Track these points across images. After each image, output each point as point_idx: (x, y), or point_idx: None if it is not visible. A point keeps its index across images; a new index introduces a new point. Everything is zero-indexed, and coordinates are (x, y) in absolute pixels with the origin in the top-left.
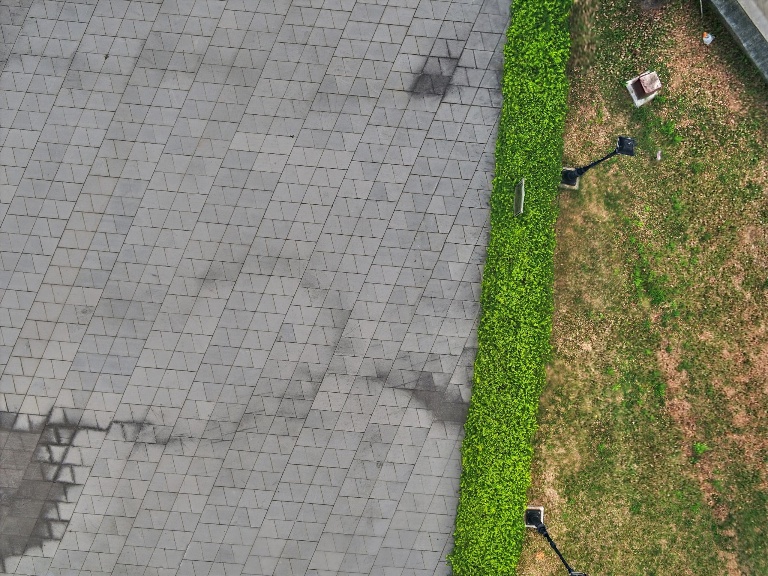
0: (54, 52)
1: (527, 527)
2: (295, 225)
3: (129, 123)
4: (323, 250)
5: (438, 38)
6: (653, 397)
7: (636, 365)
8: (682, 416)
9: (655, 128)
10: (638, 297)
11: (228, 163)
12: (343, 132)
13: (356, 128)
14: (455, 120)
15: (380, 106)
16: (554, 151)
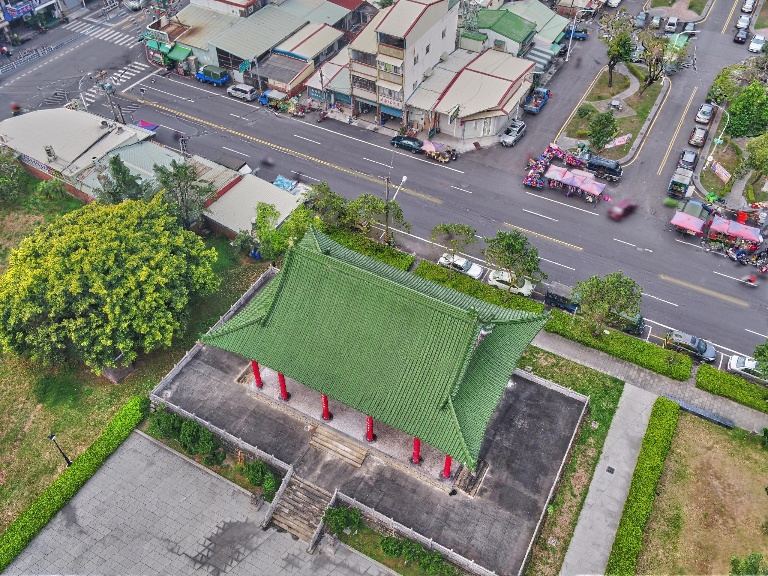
0: None
1: None
2: None
3: None
4: None
5: None
6: (5, 488)
7: (1, 500)
8: (2, 478)
9: None
10: None
11: None
12: None
13: None
14: None
15: None
16: None
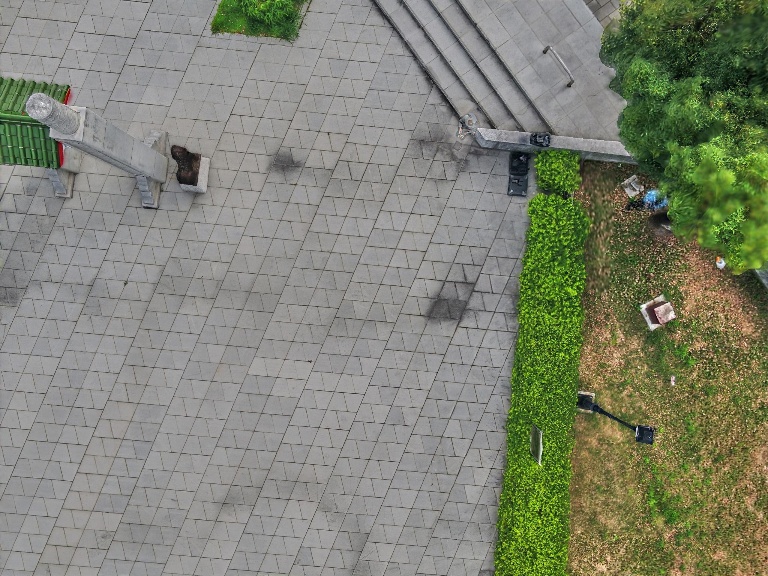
0: (74, 279)
1: None
2: (313, 449)
3: (148, 349)
4: (341, 474)
5: (454, 263)
6: None
7: None
8: None
9: (669, 351)
10: (652, 517)
11: (246, 388)
12: (360, 357)
13: (373, 353)
14: (471, 344)
15: (397, 331)
16: (570, 382)
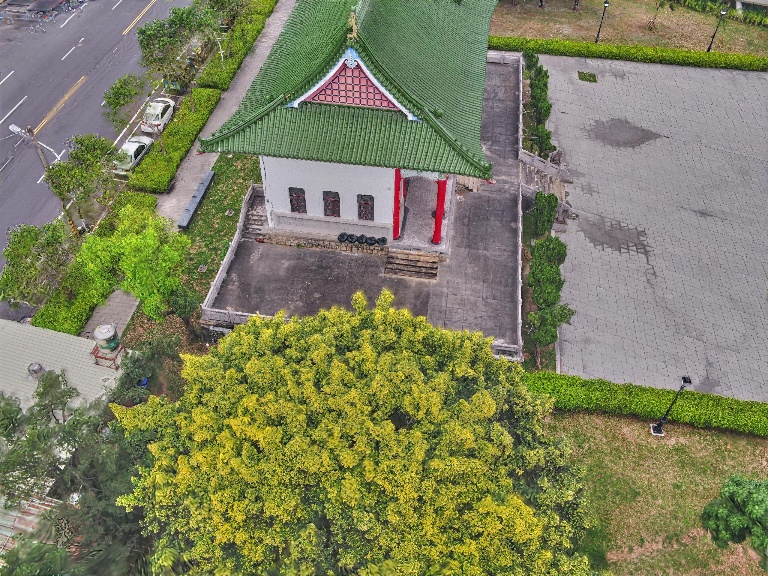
0: None
1: (651, 427)
2: None
3: None
4: (765, 343)
5: None
6: None
7: None
8: None
9: None
10: None
11: None
12: None
13: None
14: None
15: None
16: None
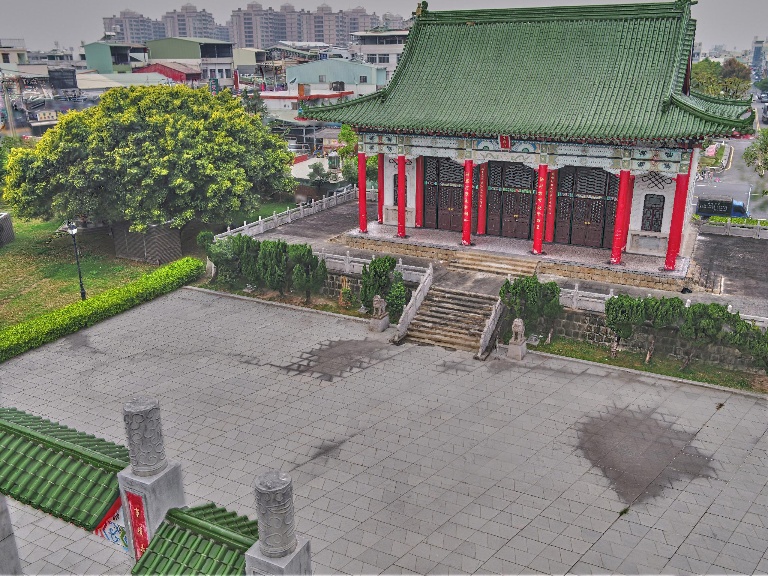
0: None
1: None
2: None
3: None
4: None
5: None
6: None
7: None
8: None
9: None
10: None
11: None
12: None
13: None
14: None
15: None
16: None
